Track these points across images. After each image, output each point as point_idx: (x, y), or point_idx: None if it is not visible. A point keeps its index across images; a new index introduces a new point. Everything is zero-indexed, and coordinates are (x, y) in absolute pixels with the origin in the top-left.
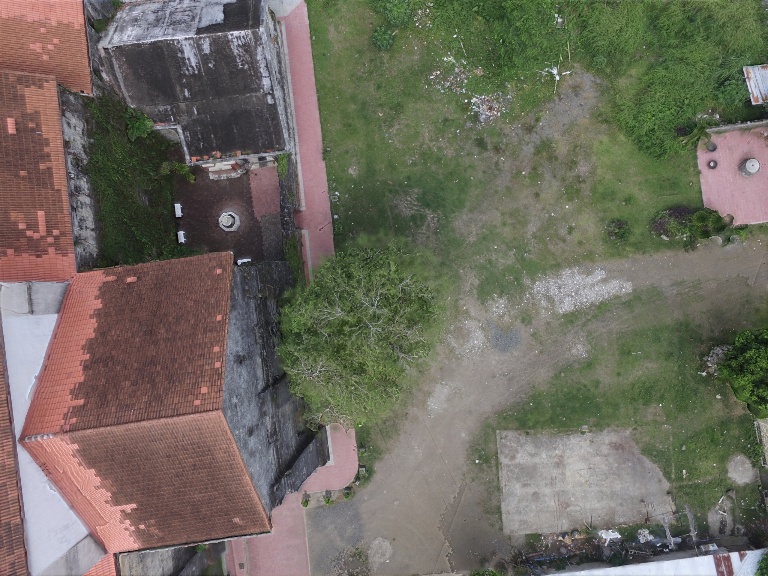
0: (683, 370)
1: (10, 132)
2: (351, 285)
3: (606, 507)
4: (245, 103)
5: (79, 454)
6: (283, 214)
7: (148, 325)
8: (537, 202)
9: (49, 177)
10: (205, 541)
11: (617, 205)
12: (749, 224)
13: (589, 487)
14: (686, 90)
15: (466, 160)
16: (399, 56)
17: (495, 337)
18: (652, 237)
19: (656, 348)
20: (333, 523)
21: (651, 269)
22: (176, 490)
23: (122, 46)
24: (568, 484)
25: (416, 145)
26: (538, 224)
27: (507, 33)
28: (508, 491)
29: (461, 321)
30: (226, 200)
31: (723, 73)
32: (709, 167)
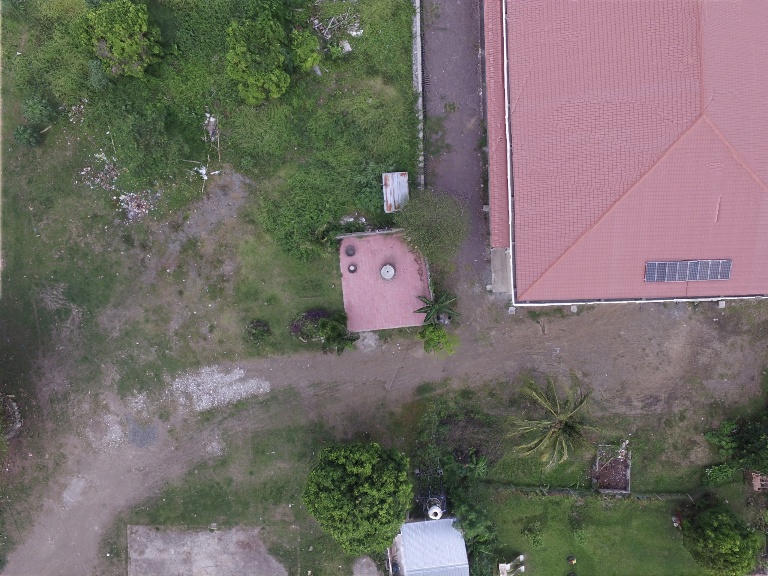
0: None
1: None
2: None
3: None
4: None
5: None
6: None
7: None
8: (180, 300)
9: None
10: None
11: (259, 305)
12: (388, 328)
13: None
14: (327, 194)
15: (112, 256)
16: (51, 151)
17: (133, 432)
18: (291, 338)
19: (290, 449)
20: None
21: (289, 370)
22: None
23: None
24: None
25: (62, 240)
26: (180, 322)
27: None
28: None
29: (100, 415)
30: None
31: (361, 180)
32: (349, 271)
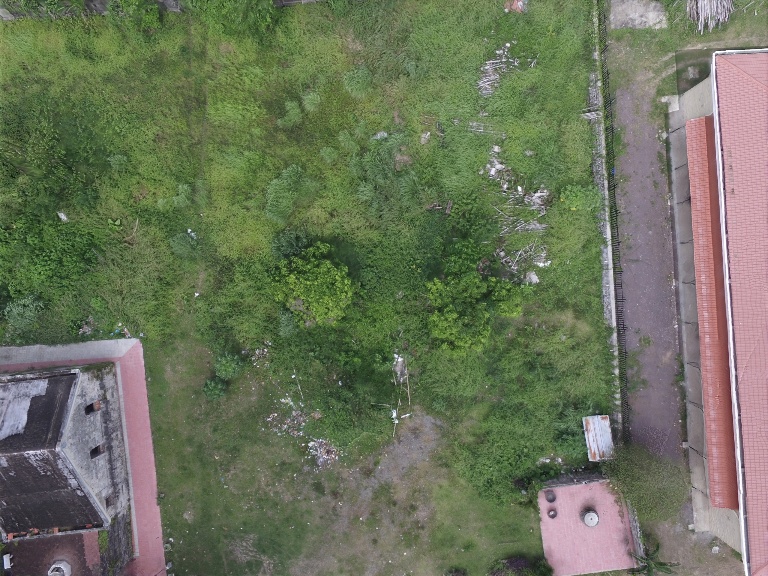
0: None
1: None
2: None
3: None
4: (54, 496)
5: None
6: None
7: None
8: (374, 549)
9: None
10: None
11: (456, 552)
12: (590, 573)
13: None
14: (525, 439)
15: (303, 505)
16: (236, 397)
17: None
18: None
19: None
20: None
21: None
22: None
23: None
24: None
25: (251, 491)
26: (375, 571)
27: (346, 374)
28: None
29: None
30: (58, 548)
31: (561, 425)
32: (549, 516)
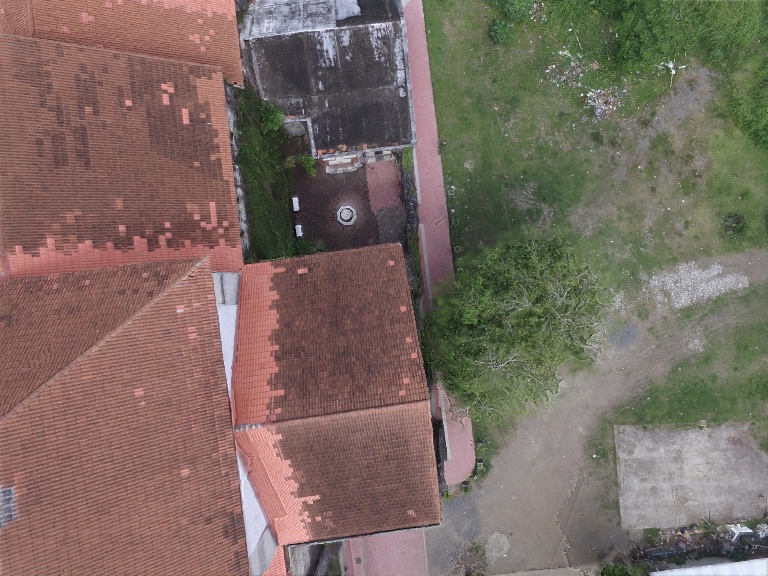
0: None
1: (185, 123)
2: (533, 276)
3: (724, 502)
4: (377, 96)
5: (280, 444)
6: (408, 208)
7: (332, 316)
8: (653, 196)
9: (218, 168)
10: (374, 533)
11: (733, 199)
12: None
13: (707, 482)
14: None
15: (582, 154)
16: (514, 50)
17: (612, 331)
18: None
19: None
20: (450, 517)
21: (767, 264)
22: (362, 481)
23: (263, 38)
24: (686, 479)
25: (532, 139)
26: (654, 218)
27: (622, 27)
28: (626, 486)
29: None
30: (342, 194)
31: None
32: None
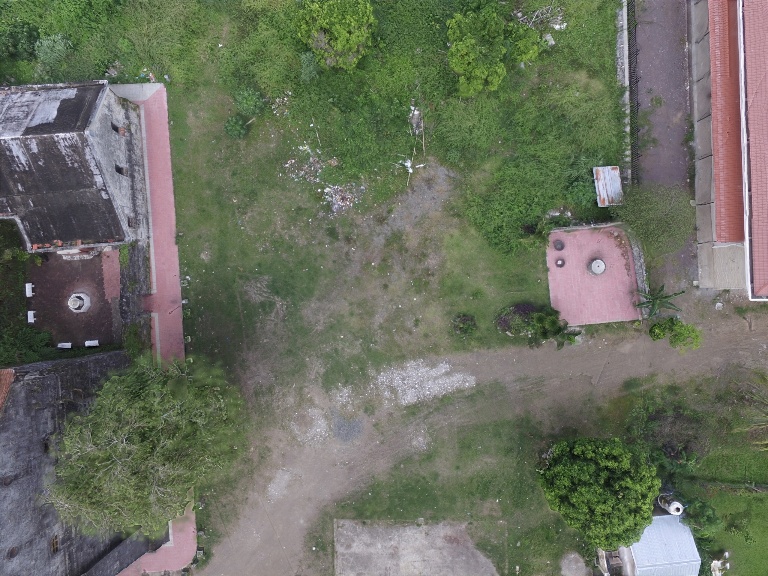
0: (522, 467)
1: None
2: (111, 417)
3: None
4: (80, 197)
5: None
6: (121, 303)
7: None
8: (385, 293)
9: None
10: None
11: (465, 299)
12: (595, 323)
13: None
14: (536, 188)
15: (317, 249)
16: (255, 143)
17: (338, 426)
18: (497, 333)
19: (496, 443)
20: None
21: (495, 364)
22: None
23: None
24: (402, 575)
25: (267, 233)
26: (385, 315)
27: None
28: None
29: (305, 409)
30: (78, 281)
31: (572, 174)
32: (557, 265)
